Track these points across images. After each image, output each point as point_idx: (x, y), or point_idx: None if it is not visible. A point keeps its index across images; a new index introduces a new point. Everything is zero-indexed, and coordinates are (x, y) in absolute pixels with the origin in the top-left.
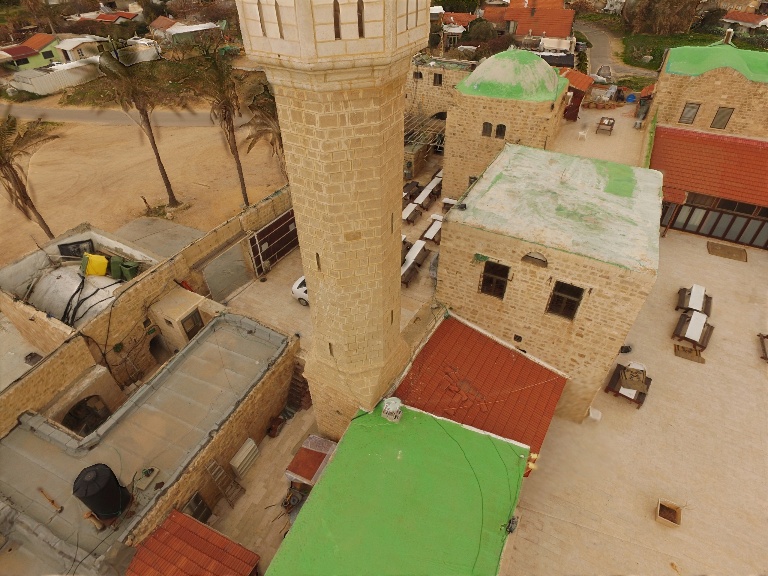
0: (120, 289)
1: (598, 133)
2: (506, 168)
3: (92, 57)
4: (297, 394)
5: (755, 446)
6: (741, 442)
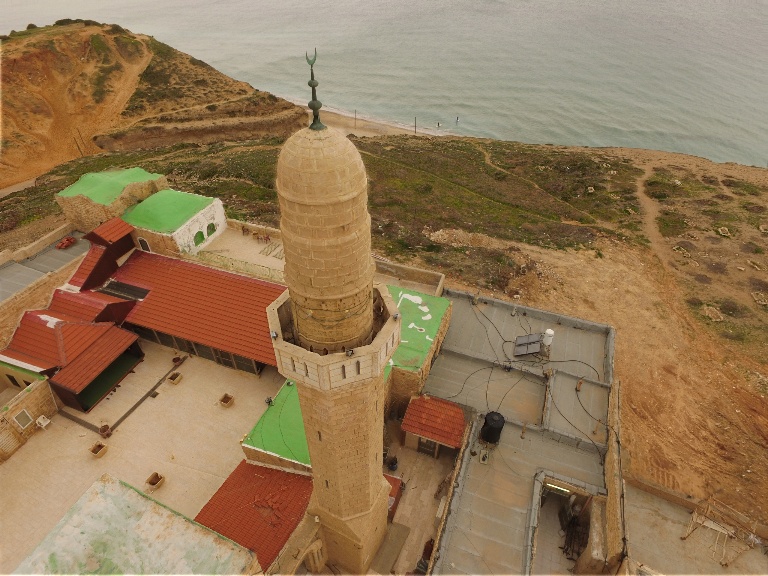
0: None
1: None
2: None
3: None
4: (417, 573)
5: None
6: None
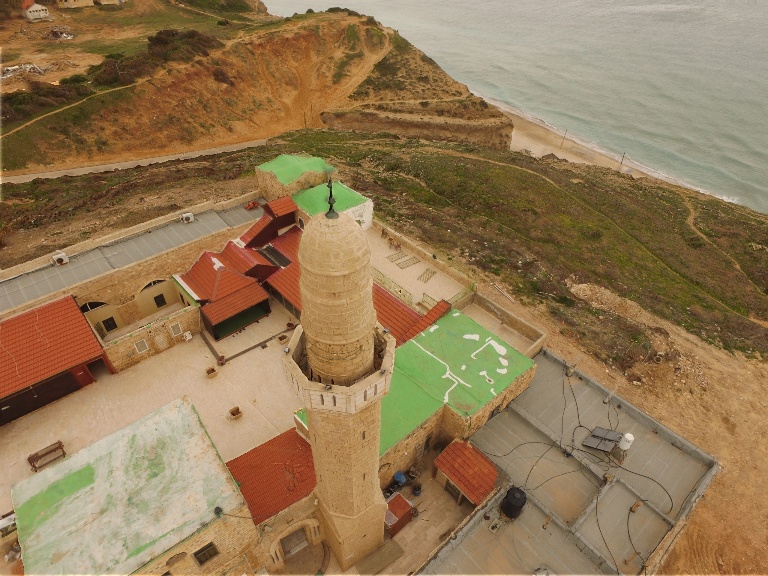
0: None
1: None
2: (112, 567)
3: None
4: None
5: None
6: None
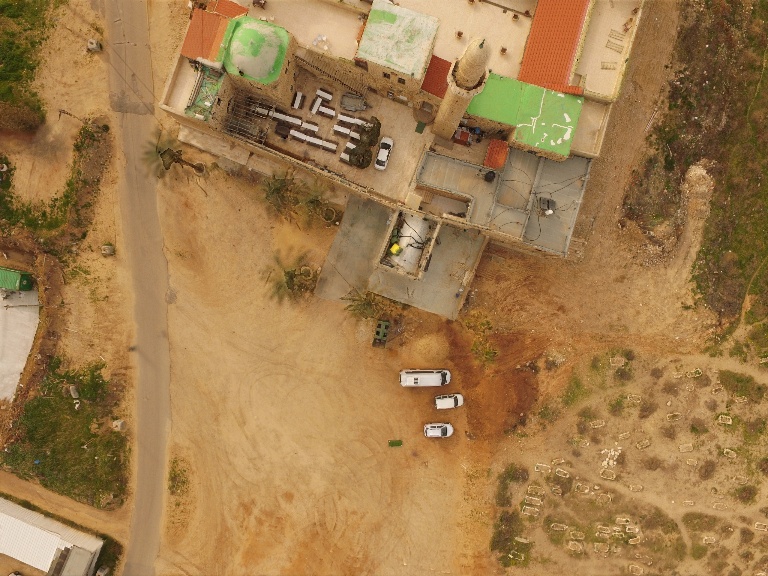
0: (422, 215)
1: (264, 8)
2: (380, 58)
3: (2, 548)
4: None
5: (432, 1)
6: (431, 4)
